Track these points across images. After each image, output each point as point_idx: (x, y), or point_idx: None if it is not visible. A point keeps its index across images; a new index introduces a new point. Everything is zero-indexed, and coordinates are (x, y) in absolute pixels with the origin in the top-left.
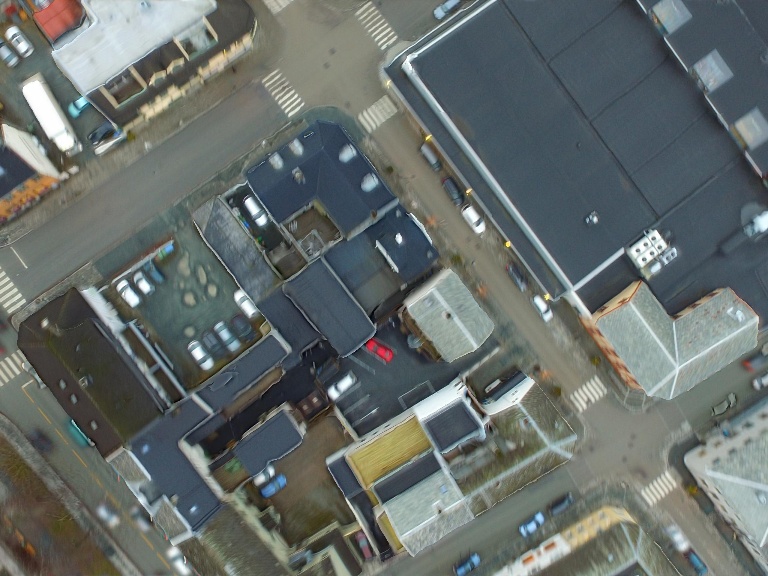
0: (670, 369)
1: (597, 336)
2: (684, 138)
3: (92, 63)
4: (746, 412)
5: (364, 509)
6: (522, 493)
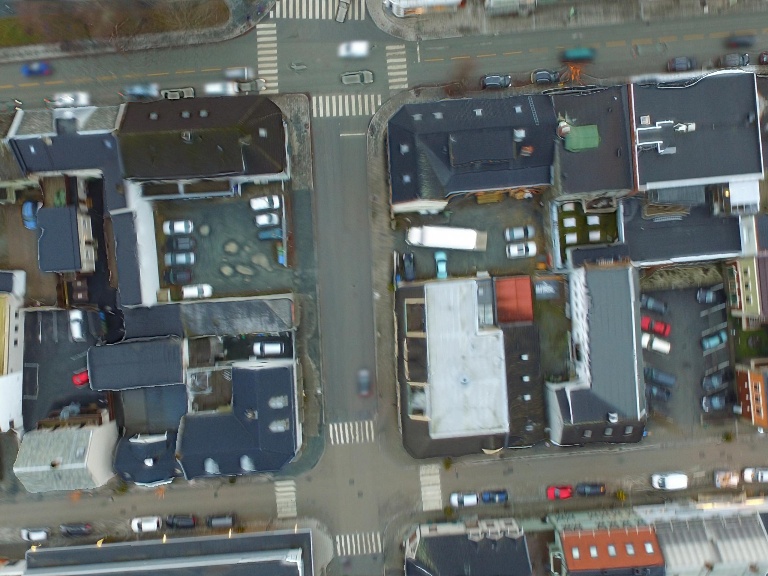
0: None
1: None
2: None
3: (449, 306)
4: None
5: None
6: None
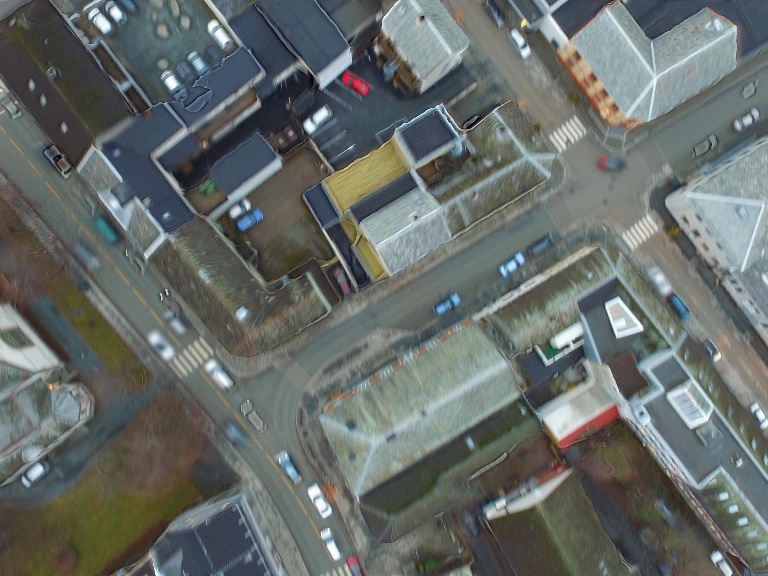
0: (648, 80)
1: (575, 68)
2: None
3: None
4: (727, 154)
5: (342, 247)
6: (502, 234)
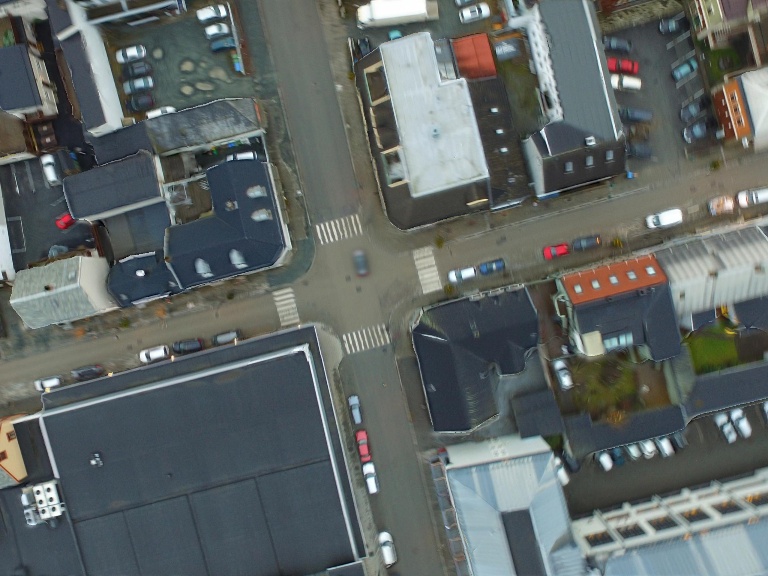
0: None
1: None
2: (137, 575)
3: (407, 64)
4: None
5: None
6: None
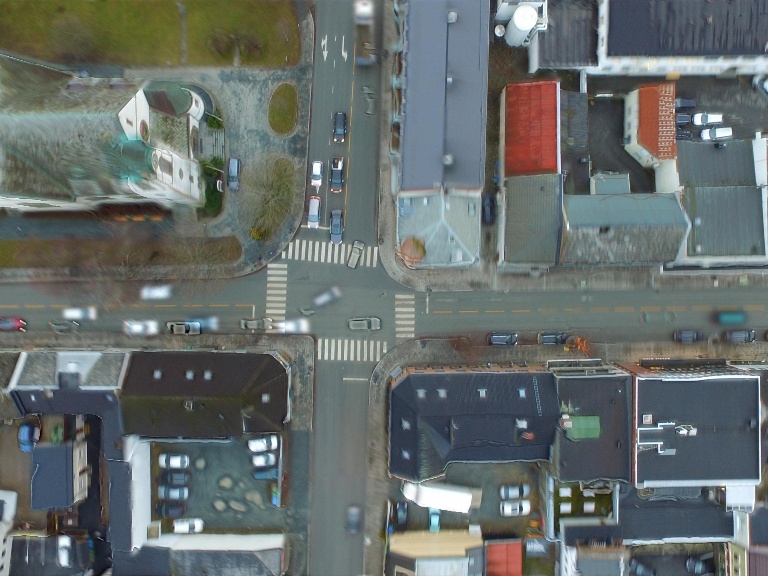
0: None
1: None
2: None
3: None
4: None
5: None
6: None
